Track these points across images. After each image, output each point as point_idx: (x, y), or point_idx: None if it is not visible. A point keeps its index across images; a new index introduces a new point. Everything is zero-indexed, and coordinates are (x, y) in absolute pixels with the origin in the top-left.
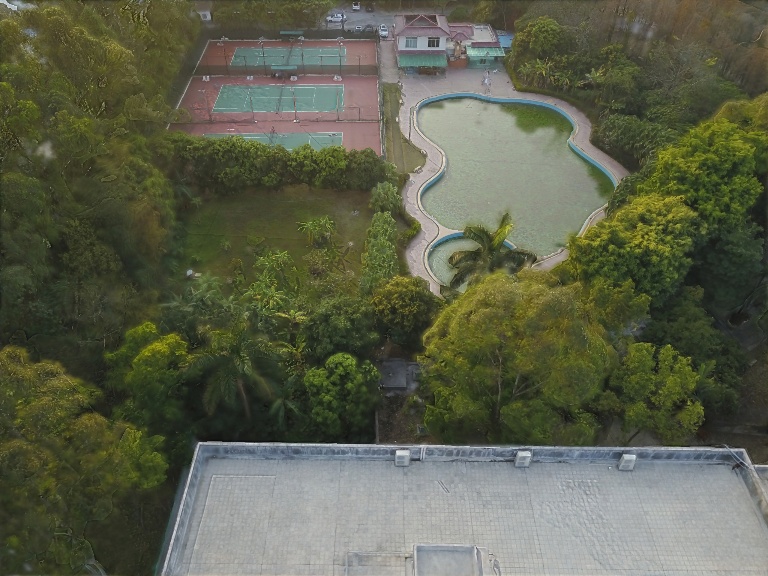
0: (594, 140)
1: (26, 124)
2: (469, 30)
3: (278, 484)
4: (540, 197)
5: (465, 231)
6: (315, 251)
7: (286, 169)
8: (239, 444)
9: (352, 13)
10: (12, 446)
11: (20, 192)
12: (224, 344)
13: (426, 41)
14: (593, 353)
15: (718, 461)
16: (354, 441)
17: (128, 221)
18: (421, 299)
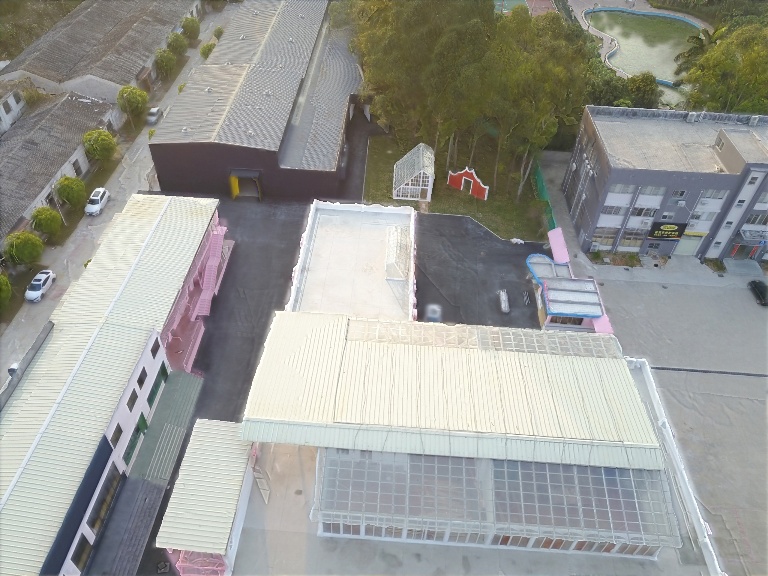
0: None
1: None
2: None
3: (630, 125)
4: None
5: (689, 38)
6: None
7: None
8: (607, 107)
9: None
10: None
11: None
12: None
13: None
14: None
15: None
16: None
17: None
18: None
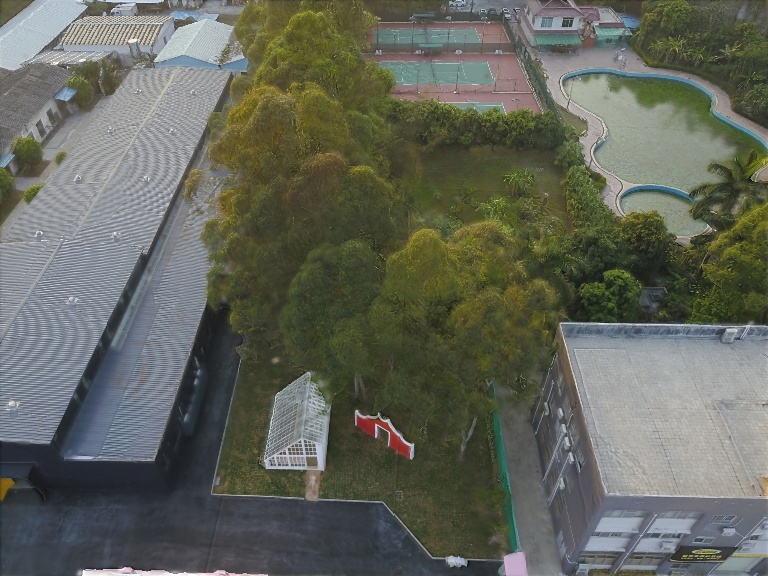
0: (738, 108)
1: (348, 72)
2: (595, 12)
3: (631, 355)
4: (701, 157)
5: (710, 167)
6: (523, 199)
7: (480, 129)
8: (593, 324)
9: None
10: (538, 284)
11: (363, 126)
12: None
13: (561, 21)
14: None
15: None
16: None
17: None
18: (662, 229)
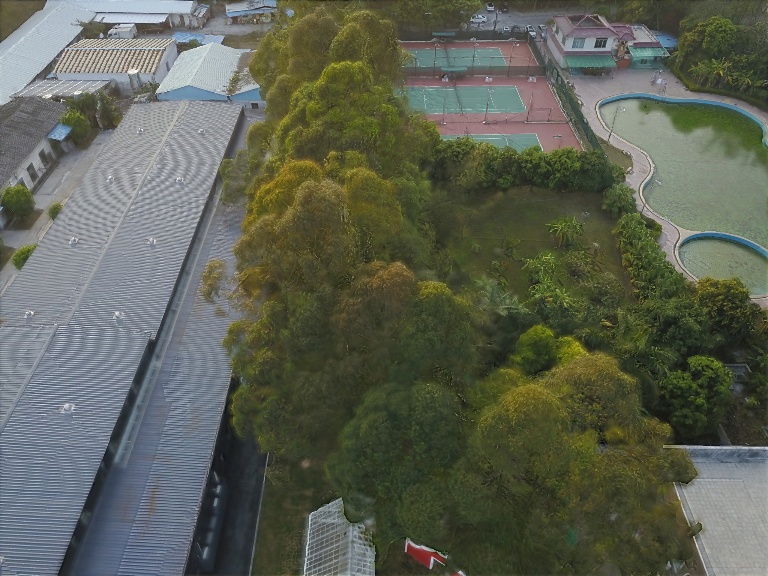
0: None
1: (389, 128)
2: (628, 30)
3: (750, 488)
4: (760, 197)
5: None
6: (573, 253)
7: (519, 171)
8: (701, 448)
9: (487, 14)
10: (677, 452)
11: (411, 196)
12: None
13: (593, 42)
14: None
15: None
16: (702, 443)
17: (463, 224)
18: (746, 301)
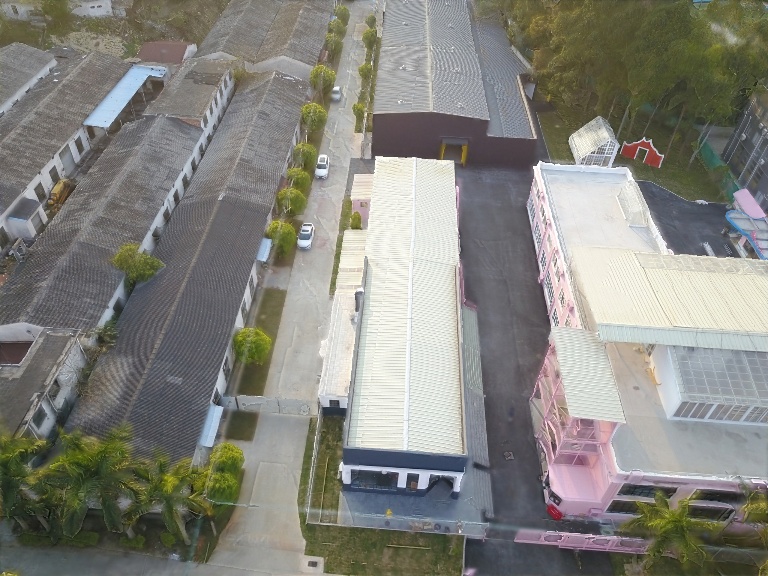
0: None
1: None
2: None
3: None
4: None
5: None
6: None
7: None
8: None
9: None
10: None
11: None
12: None
13: None
14: None
15: None
16: None
17: None
18: None
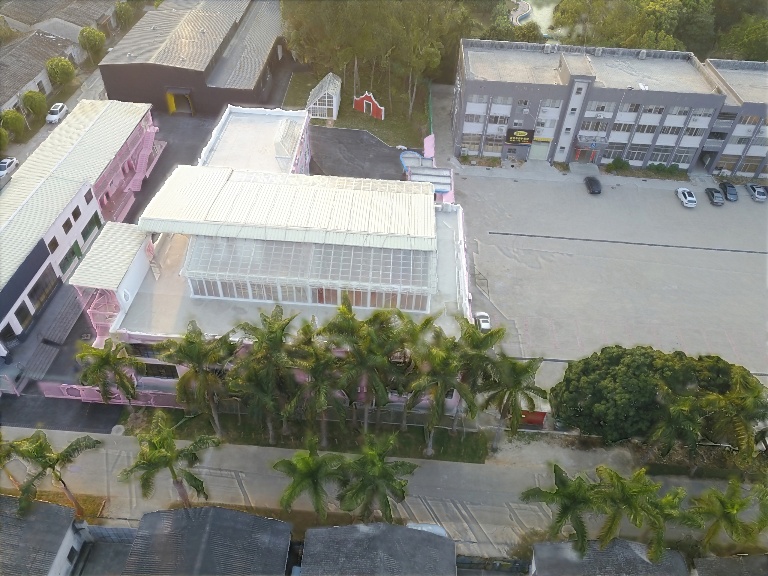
0: None
1: None
2: None
3: (496, 54)
4: None
5: None
6: None
7: None
8: (479, 40)
9: None
10: None
11: None
12: (460, 16)
13: None
14: (631, 3)
15: (681, 60)
16: None
17: None
18: (538, 31)
